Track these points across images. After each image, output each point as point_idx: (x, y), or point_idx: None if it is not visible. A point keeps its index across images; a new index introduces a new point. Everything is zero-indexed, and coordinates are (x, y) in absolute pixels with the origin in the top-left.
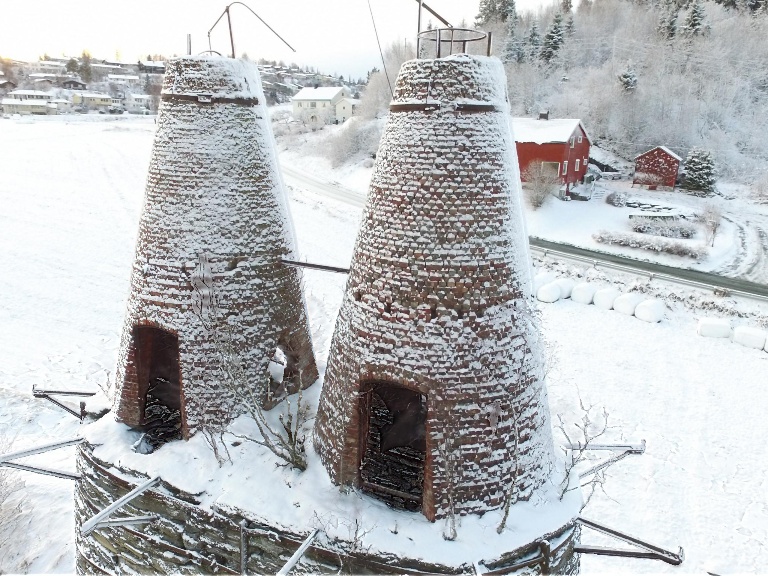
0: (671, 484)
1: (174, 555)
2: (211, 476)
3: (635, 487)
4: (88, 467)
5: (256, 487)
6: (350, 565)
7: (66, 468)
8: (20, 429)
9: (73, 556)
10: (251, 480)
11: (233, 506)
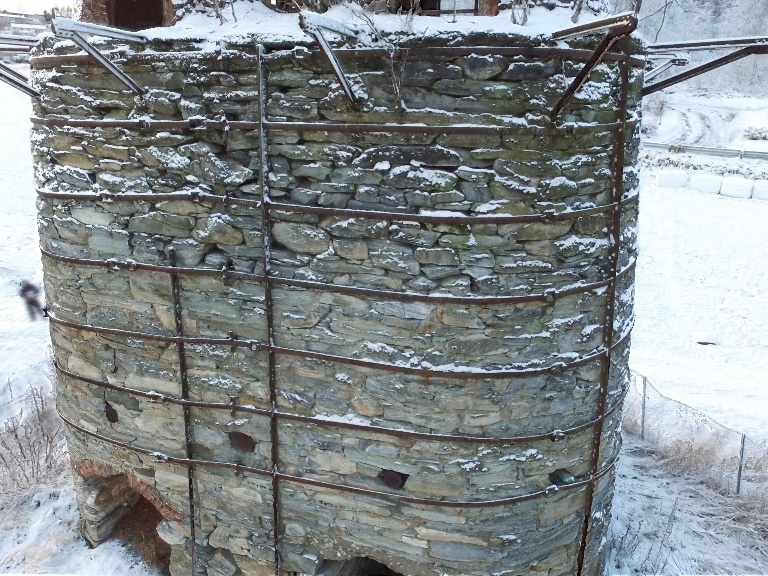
0: (651, 284)
1: (170, 135)
2: (211, 28)
3: None
4: (48, 72)
5: (271, 24)
6: (401, 64)
7: (4, 316)
8: None
9: (22, 382)
10: (263, 23)
11: (246, 33)
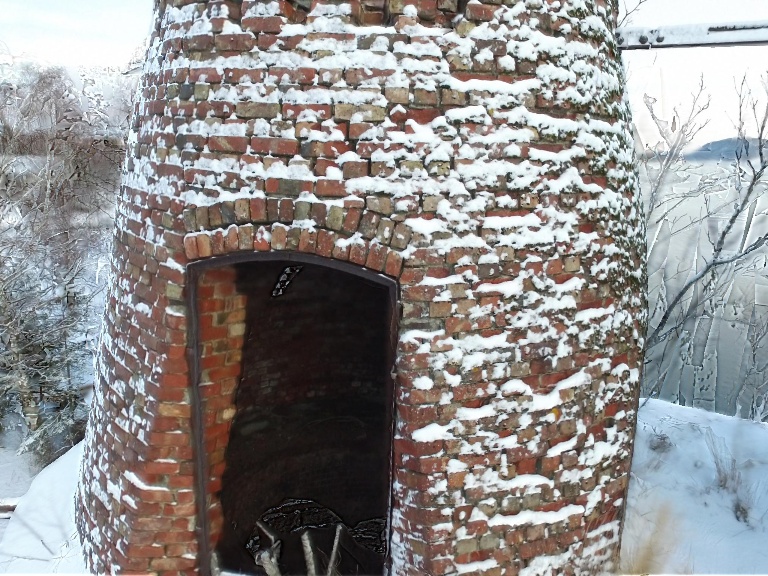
0: None
1: None
2: None
3: None
4: None
5: None
6: None
7: None
8: None
9: None
10: None
11: None
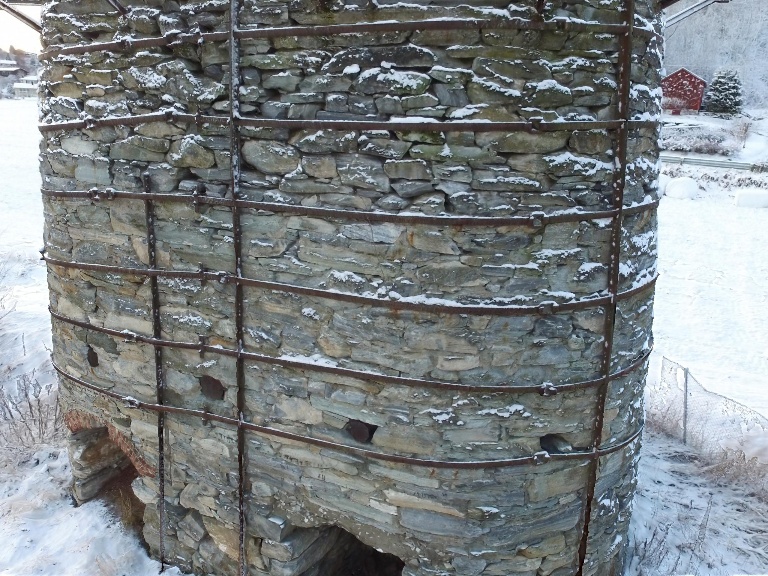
0: (719, 299)
1: (149, 53)
2: None
3: (679, 302)
4: (48, 4)
5: None
6: None
7: None
8: (5, 230)
9: None
10: None
11: None
